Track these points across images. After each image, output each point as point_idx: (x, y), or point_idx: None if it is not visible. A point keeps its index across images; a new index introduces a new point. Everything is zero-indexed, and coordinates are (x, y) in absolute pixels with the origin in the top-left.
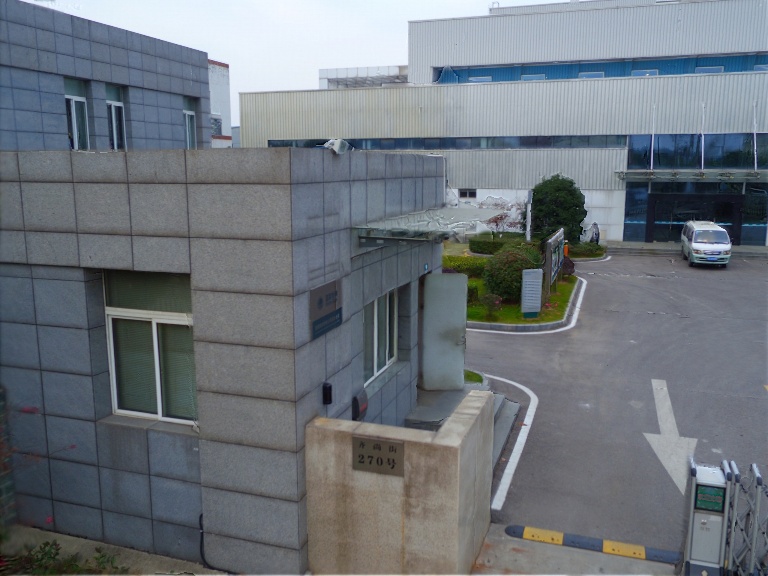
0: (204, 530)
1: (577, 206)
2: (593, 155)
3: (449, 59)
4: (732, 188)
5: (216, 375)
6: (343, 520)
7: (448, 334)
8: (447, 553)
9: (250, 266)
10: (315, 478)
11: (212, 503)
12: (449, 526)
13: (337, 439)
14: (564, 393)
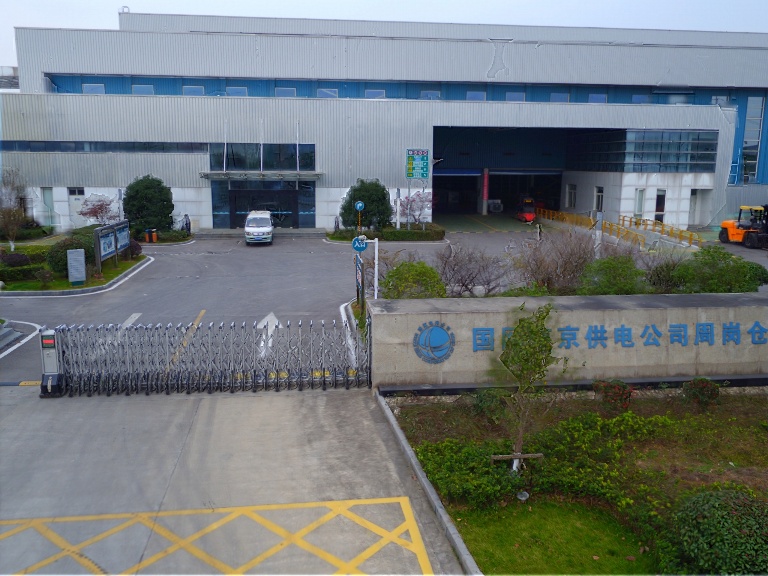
0: None
1: (164, 201)
2: (182, 159)
3: (59, 66)
4: (289, 185)
5: None
6: None
7: None
8: None
9: None
10: None
11: None
12: None
13: None
14: None
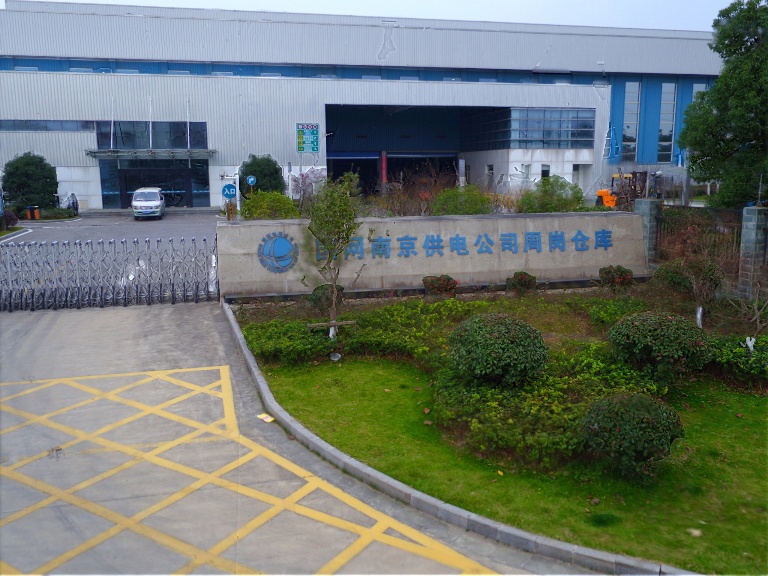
0: None
1: (47, 178)
2: (67, 137)
3: None
4: (181, 164)
5: None
6: None
7: None
8: None
9: None
10: None
11: None
12: None
13: None
14: None
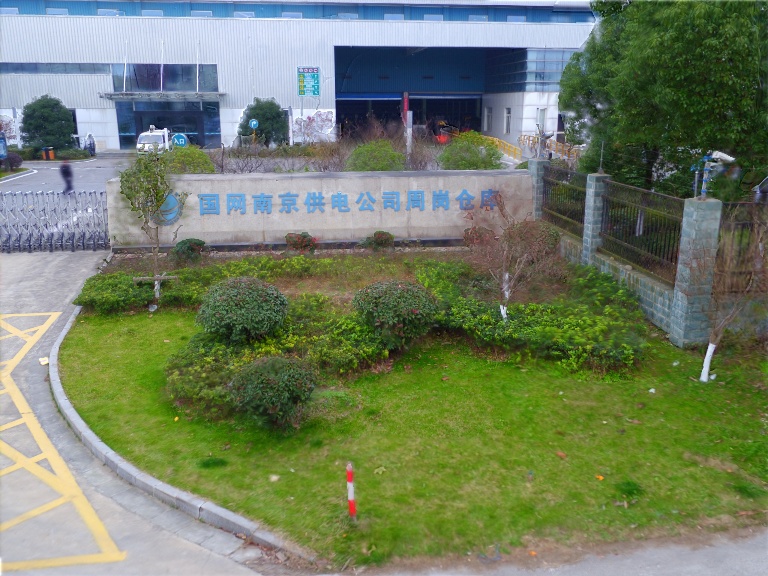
0: None
1: (62, 120)
2: (85, 80)
3: None
4: (193, 106)
5: None
6: None
7: None
8: None
9: None
10: None
11: None
12: None
13: None
14: None
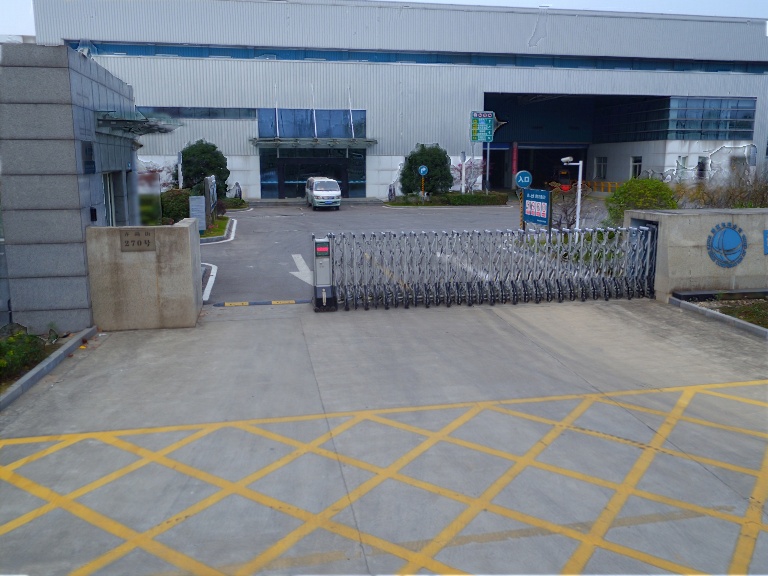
0: (12, 310)
1: (221, 166)
2: (230, 125)
3: (80, 32)
4: (339, 153)
5: (17, 198)
6: (117, 286)
7: (148, 217)
8: (186, 293)
9: (41, 121)
10: (95, 262)
11: (18, 289)
12: (186, 276)
13: (109, 234)
14: (234, 263)
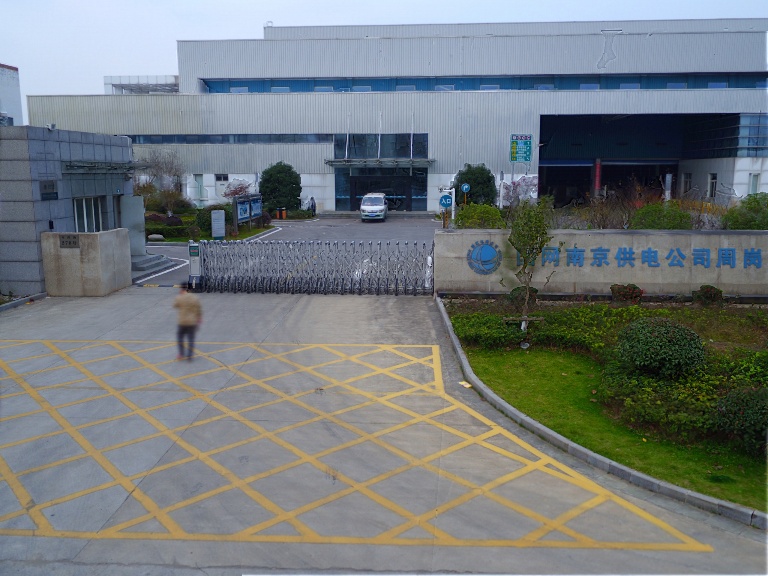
0: None
1: (294, 184)
2: (310, 148)
3: (212, 72)
4: (403, 171)
5: (2, 214)
6: (58, 269)
7: (135, 227)
8: (98, 275)
9: (14, 170)
10: (46, 254)
11: (3, 268)
12: (97, 264)
13: (53, 237)
14: None
